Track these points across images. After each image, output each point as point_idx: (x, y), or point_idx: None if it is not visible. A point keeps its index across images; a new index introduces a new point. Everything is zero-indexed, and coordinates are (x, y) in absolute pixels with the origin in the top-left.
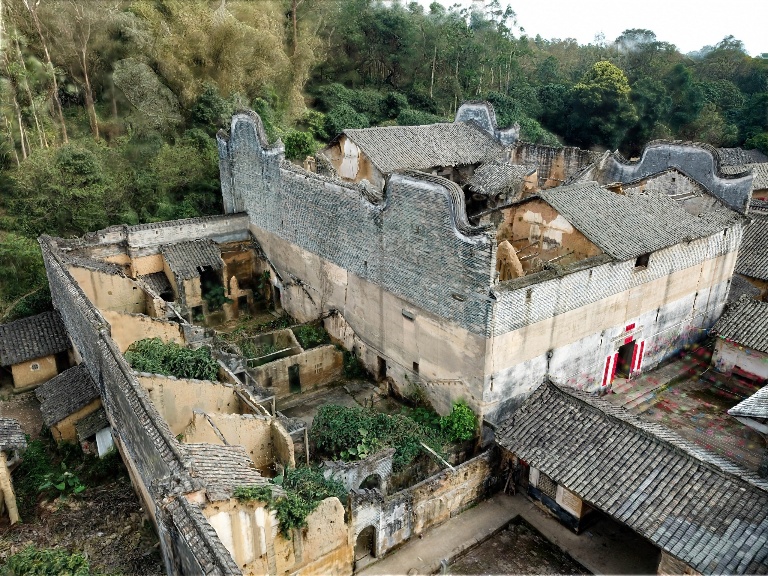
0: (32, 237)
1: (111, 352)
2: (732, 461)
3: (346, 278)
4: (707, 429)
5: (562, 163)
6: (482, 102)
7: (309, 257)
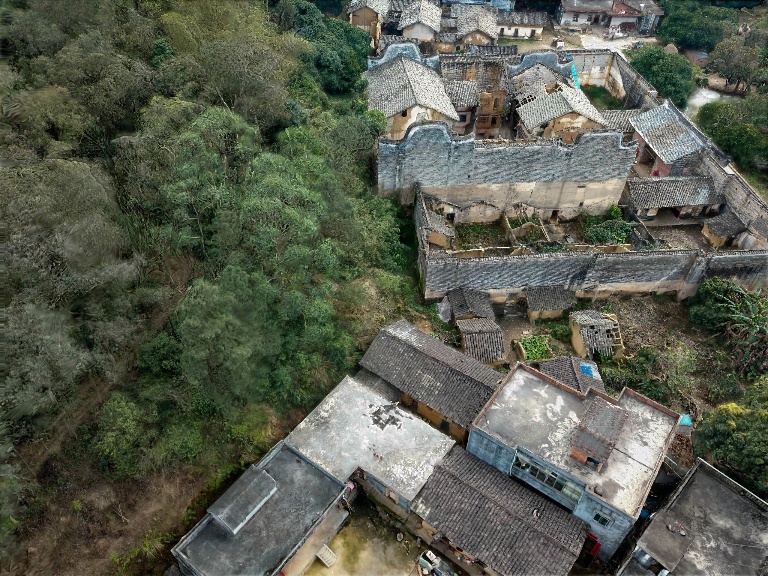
0: (356, 276)
1: (615, 254)
2: None
3: (534, 186)
4: None
5: (474, 70)
6: (410, 41)
7: (498, 186)
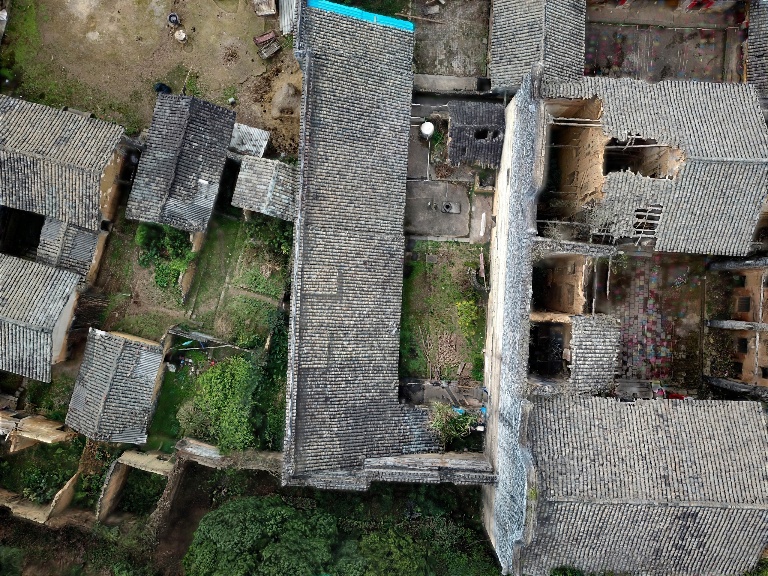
0: None
1: None
2: (752, 5)
3: None
4: (631, 71)
5: None
6: None
7: None
